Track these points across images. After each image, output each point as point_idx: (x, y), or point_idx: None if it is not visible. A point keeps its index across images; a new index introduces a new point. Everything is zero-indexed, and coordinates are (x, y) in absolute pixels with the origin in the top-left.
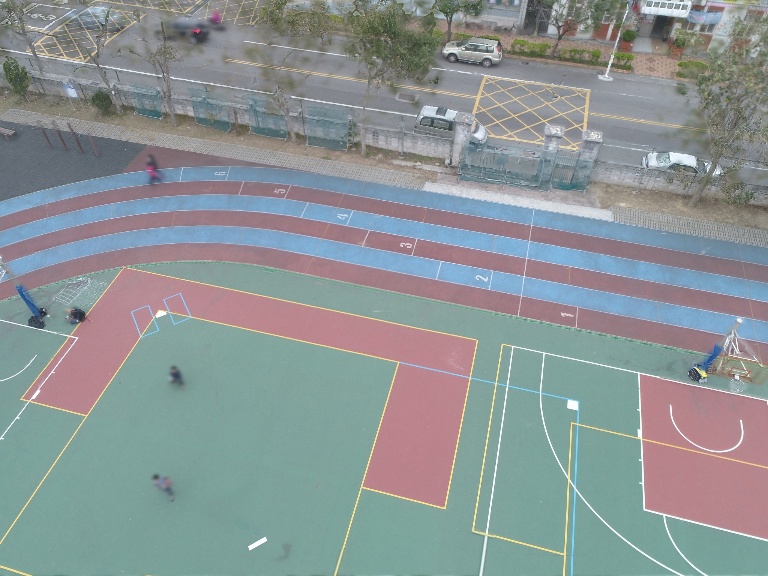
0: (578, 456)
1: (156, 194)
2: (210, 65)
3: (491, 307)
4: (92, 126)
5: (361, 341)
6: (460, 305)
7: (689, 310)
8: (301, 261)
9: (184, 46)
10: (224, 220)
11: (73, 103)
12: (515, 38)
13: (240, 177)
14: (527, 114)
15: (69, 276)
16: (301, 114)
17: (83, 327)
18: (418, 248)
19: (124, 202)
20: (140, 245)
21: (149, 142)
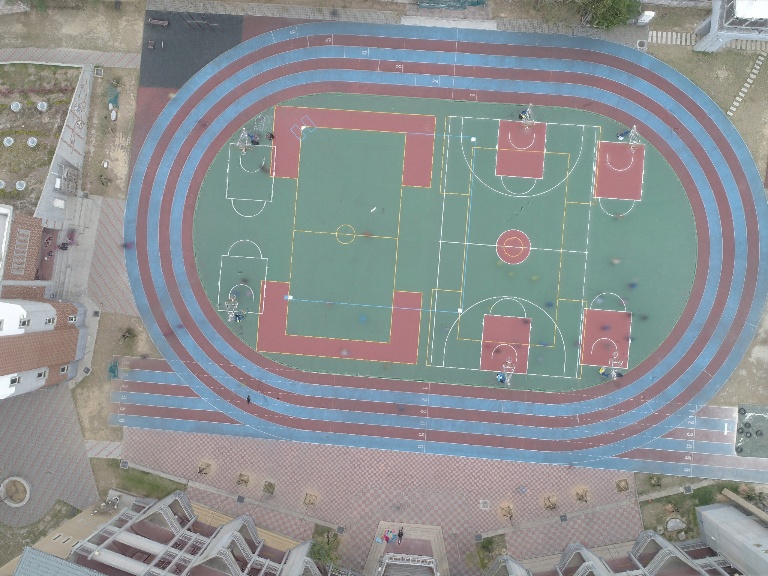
0: (474, 160)
1: (267, 55)
2: None
3: (440, 97)
4: (204, 4)
5: (389, 126)
6: (427, 98)
7: (524, 82)
8: (353, 86)
9: None
10: (308, 67)
11: None
12: None
13: (304, 33)
14: None
15: (254, 115)
16: None
17: (275, 141)
18: (404, 68)
19: (254, 64)
20: (276, 91)
21: (243, 13)
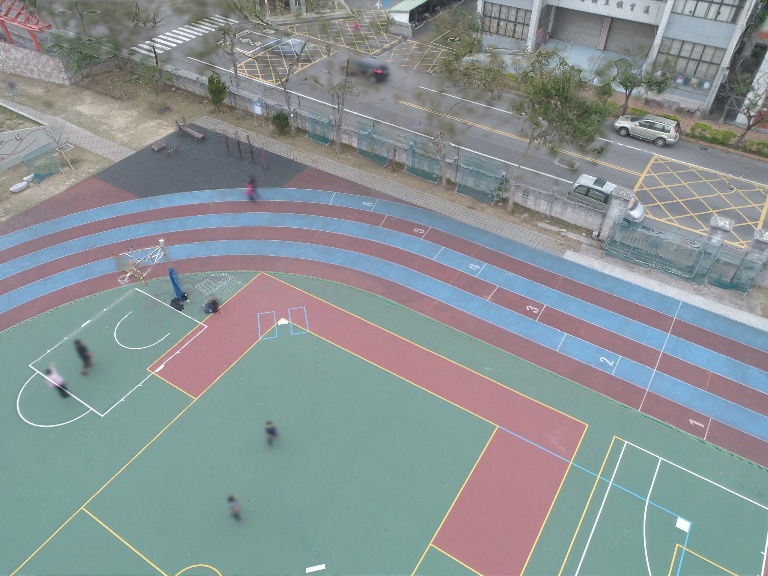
0: None
1: (306, 212)
2: (383, 104)
3: (610, 394)
4: (267, 141)
5: (464, 395)
6: (577, 383)
7: None
8: (423, 302)
9: (364, 83)
10: (361, 247)
11: (257, 119)
12: (697, 121)
13: (385, 210)
14: (694, 201)
15: (214, 269)
16: (456, 162)
17: (214, 318)
18: (544, 315)
19: (277, 213)
20: (281, 255)
21: (312, 164)
